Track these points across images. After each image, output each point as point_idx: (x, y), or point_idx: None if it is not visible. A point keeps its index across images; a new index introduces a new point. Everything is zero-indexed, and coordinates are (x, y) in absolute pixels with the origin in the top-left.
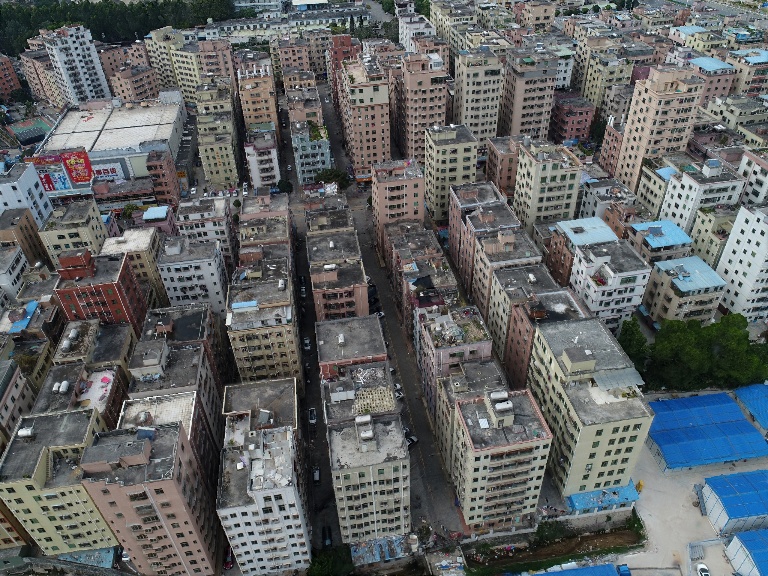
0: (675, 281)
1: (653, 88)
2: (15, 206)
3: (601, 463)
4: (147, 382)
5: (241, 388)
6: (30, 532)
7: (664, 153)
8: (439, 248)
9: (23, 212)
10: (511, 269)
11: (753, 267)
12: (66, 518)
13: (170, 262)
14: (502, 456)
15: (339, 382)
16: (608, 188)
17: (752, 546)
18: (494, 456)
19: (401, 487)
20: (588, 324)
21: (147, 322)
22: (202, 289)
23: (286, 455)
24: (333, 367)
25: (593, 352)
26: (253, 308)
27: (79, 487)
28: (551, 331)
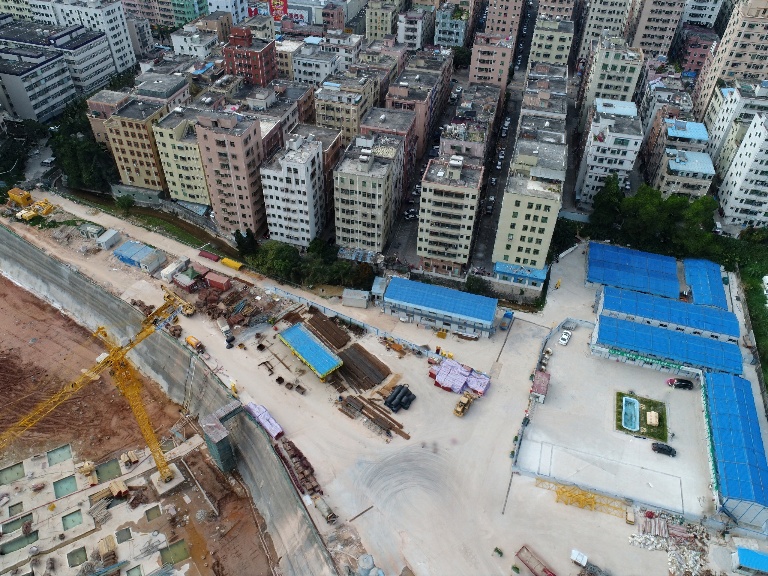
0: (671, 161)
1: (744, 11)
2: (223, 10)
3: (520, 237)
4: (255, 110)
5: (307, 127)
6: (166, 173)
7: (740, 77)
8: (497, 99)
9: (227, 14)
10: (537, 118)
11: (746, 167)
12: (186, 169)
13: (301, 57)
14: (442, 194)
15: (365, 134)
16: (670, 94)
17: (605, 322)
18: (436, 192)
19: (377, 204)
20: (556, 147)
21: (271, 84)
22: (318, 85)
23: (310, 153)
24: (369, 132)
25: (544, 159)
26: (337, 88)
27: (196, 146)
28: (525, 143)
